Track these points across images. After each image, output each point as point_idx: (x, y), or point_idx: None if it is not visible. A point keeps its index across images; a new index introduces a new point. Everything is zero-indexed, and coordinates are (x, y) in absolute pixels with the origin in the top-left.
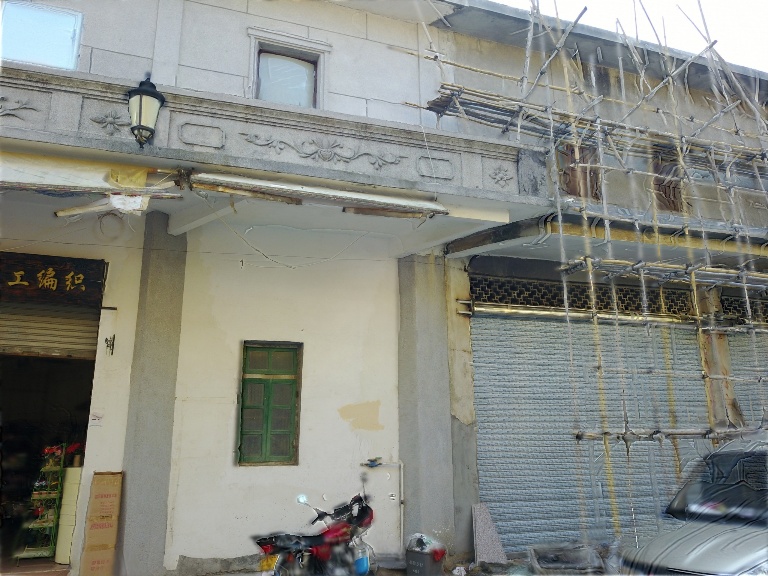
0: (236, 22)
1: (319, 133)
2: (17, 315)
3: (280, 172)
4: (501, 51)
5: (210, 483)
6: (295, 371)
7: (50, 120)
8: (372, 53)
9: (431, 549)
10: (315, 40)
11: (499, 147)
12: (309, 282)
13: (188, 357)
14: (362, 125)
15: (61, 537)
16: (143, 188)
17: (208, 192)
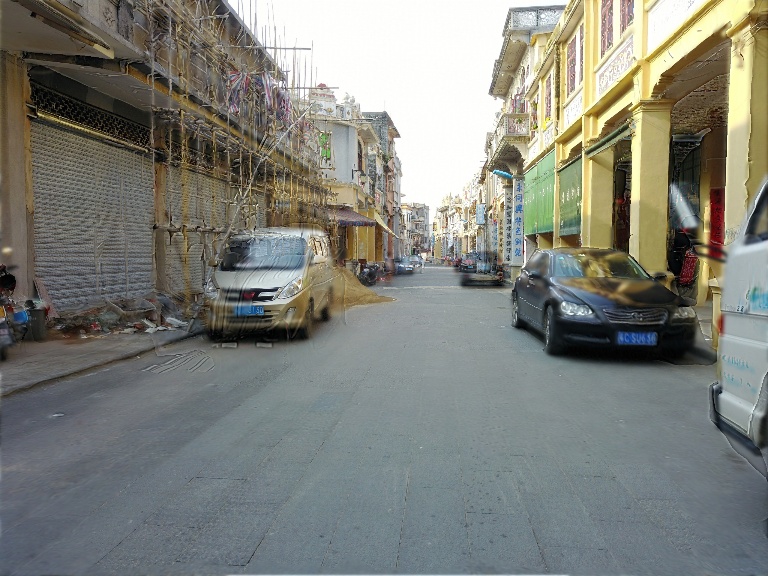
0: None
1: None
2: None
3: None
4: None
5: None
6: None
7: None
8: None
9: (42, 307)
10: None
11: None
12: None
13: None
14: None
15: None
16: None
17: None
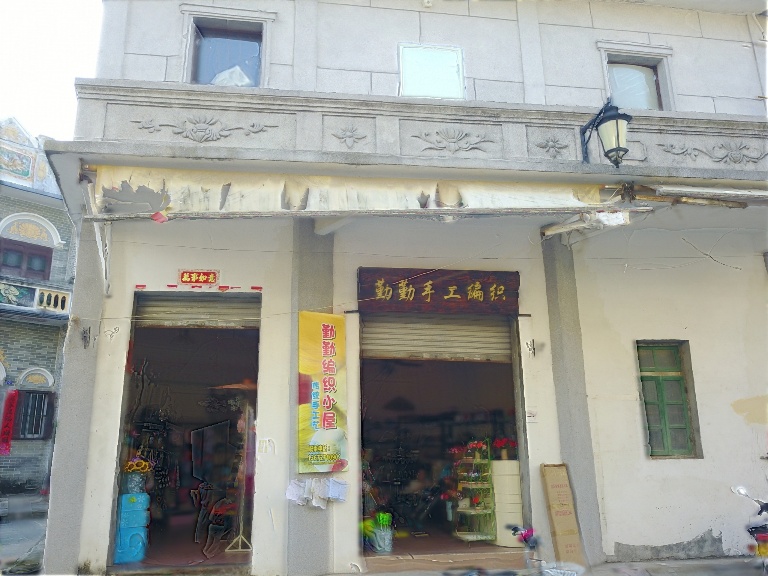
0: (585, 38)
1: (726, 137)
2: (442, 325)
3: (716, 178)
4: None
5: (630, 475)
6: (679, 368)
7: (505, 150)
8: (709, 51)
9: None
10: (657, 45)
11: None
12: (685, 281)
13: (591, 358)
14: (765, 124)
15: (502, 523)
16: (599, 204)
17: (650, 203)
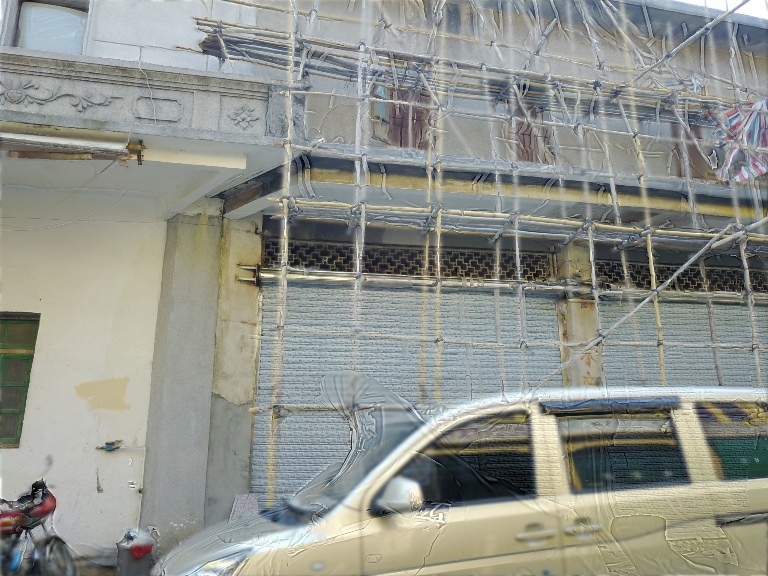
0: None
1: (9, 73)
2: None
3: None
4: None
5: None
6: None
7: None
8: None
9: (134, 544)
10: None
11: (243, 84)
12: (54, 247)
13: None
14: (63, 63)
15: None
16: None
17: None
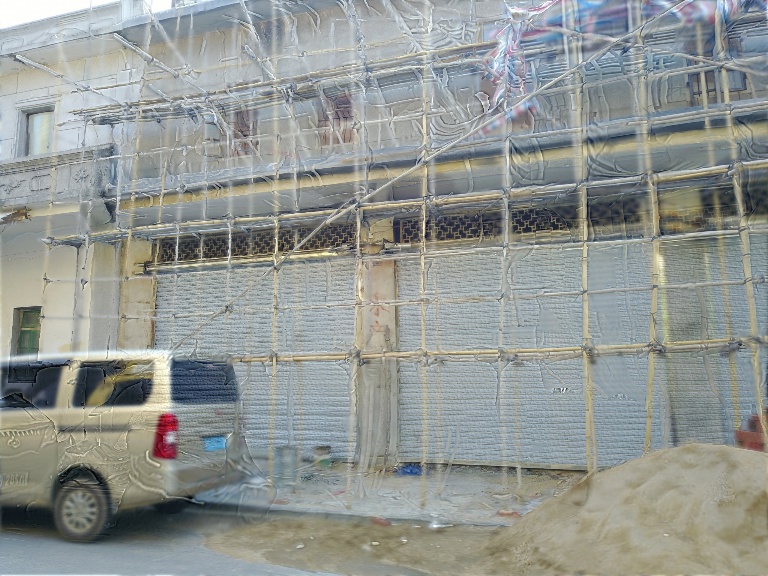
0: (11, 102)
1: None
2: None
3: None
4: (182, 45)
5: None
6: None
7: None
8: None
9: None
10: None
11: (79, 154)
12: (47, 266)
13: None
14: None
15: None
16: None
17: None
